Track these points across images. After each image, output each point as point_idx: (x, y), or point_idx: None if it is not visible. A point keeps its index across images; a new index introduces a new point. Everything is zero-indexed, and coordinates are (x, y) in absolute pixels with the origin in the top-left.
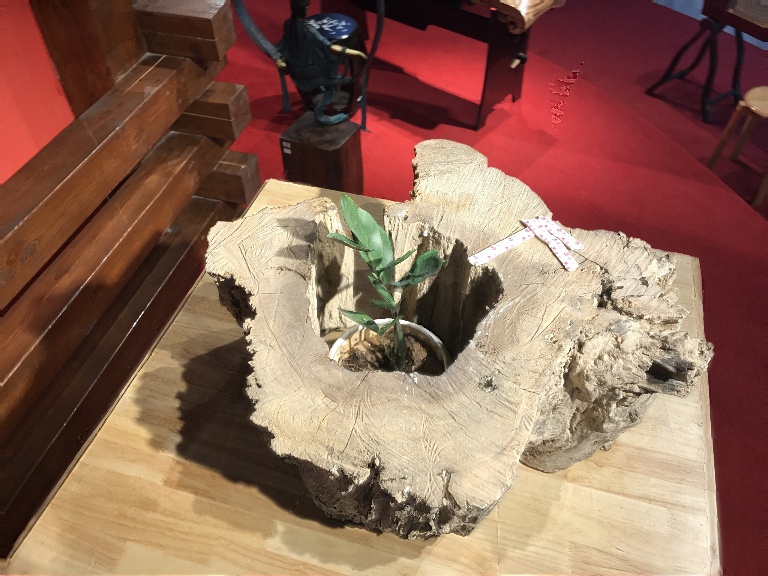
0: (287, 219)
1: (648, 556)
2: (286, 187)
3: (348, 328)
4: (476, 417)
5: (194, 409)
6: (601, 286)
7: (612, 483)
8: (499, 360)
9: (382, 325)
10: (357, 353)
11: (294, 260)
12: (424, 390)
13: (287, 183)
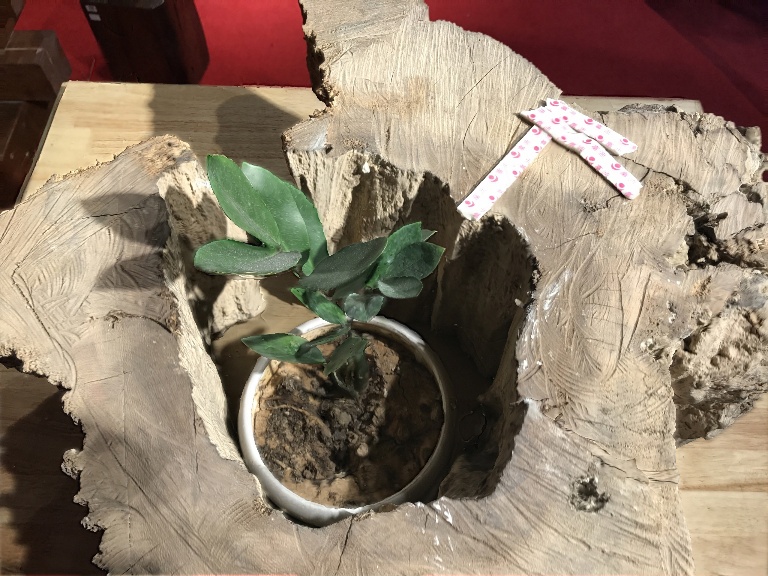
0: (101, 198)
1: (762, 575)
2: (97, 91)
3: (254, 317)
4: (588, 575)
5: (35, 519)
6: (691, 219)
7: (687, 473)
8: (580, 419)
9: (317, 328)
10: (287, 385)
11: (136, 292)
12: (471, 536)
13: (97, 84)
